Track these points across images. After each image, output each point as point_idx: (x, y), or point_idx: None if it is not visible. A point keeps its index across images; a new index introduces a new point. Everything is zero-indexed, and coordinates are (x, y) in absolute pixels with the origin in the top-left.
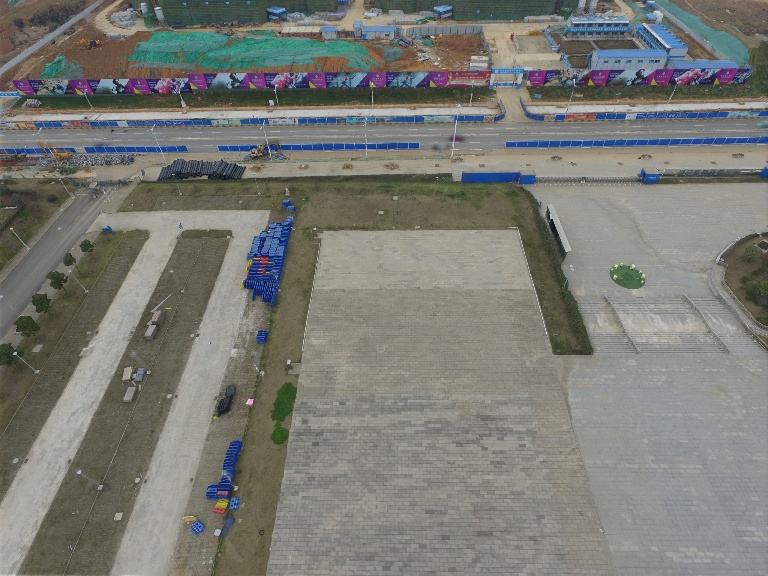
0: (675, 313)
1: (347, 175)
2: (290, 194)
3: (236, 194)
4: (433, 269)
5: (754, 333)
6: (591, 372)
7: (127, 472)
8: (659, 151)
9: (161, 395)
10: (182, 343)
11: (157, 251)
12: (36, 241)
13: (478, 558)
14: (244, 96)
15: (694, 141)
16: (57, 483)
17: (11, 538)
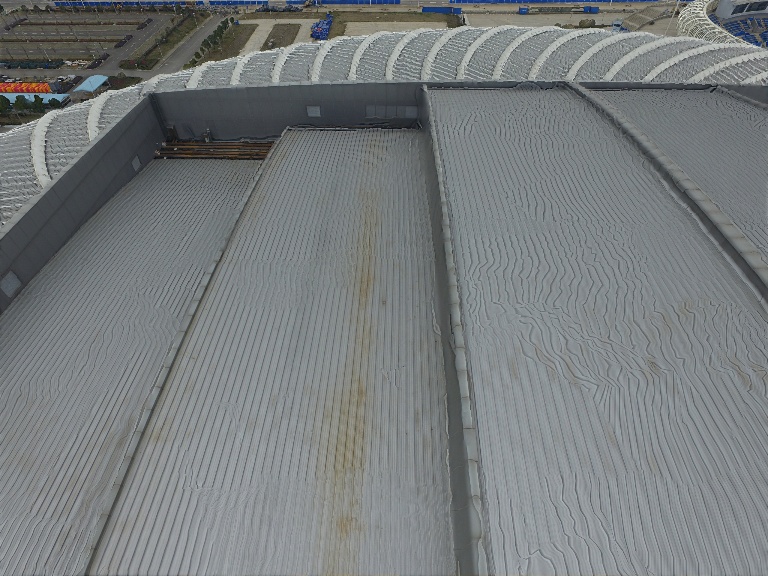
0: None
1: None
2: (330, 14)
3: (301, 14)
4: None
5: None
6: None
7: None
8: (535, 5)
9: None
10: None
11: (264, 29)
12: (201, 27)
13: None
14: None
15: (555, 0)
16: None
17: None
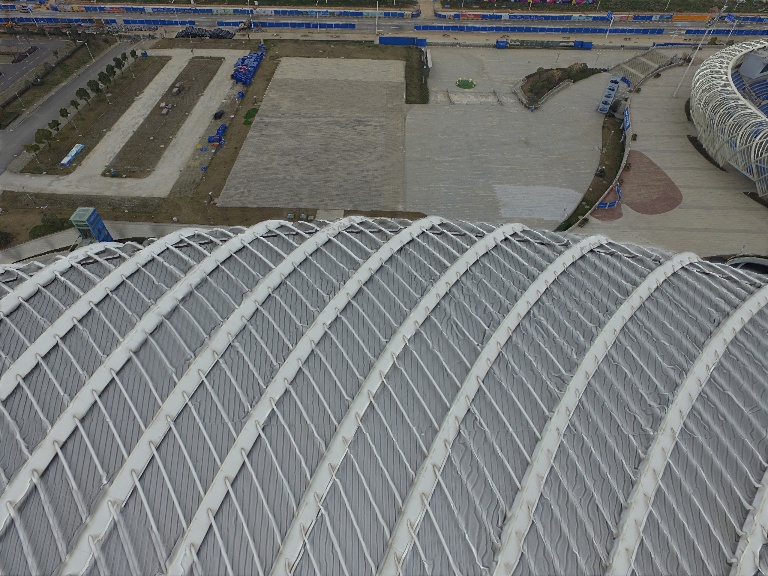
0: (484, 95)
1: (304, 39)
2: (264, 43)
3: (228, 42)
4: (347, 73)
5: (521, 100)
6: (423, 109)
7: (165, 135)
8: (516, 35)
9: (182, 113)
10: (194, 97)
11: (177, 64)
12: (98, 58)
13: (341, 156)
14: None
15: (540, 30)
16: (128, 137)
17: (107, 150)
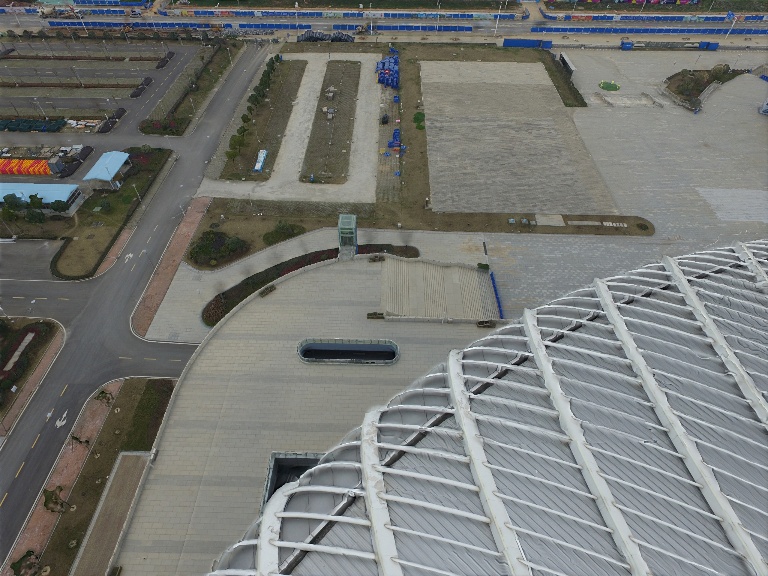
0: (635, 97)
1: (425, 42)
2: None
3: (356, 46)
4: (492, 76)
5: (678, 102)
6: (586, 112)
7: (341, 140)
8: (634, 36)
9: (347, 118)
10: (350, 102)
11: (316, 68)
12: (235, 63)
13: (530, 160)
14: (339, 2)
15: (658, 31)
16: (306, 142)
17: (293, 156)
